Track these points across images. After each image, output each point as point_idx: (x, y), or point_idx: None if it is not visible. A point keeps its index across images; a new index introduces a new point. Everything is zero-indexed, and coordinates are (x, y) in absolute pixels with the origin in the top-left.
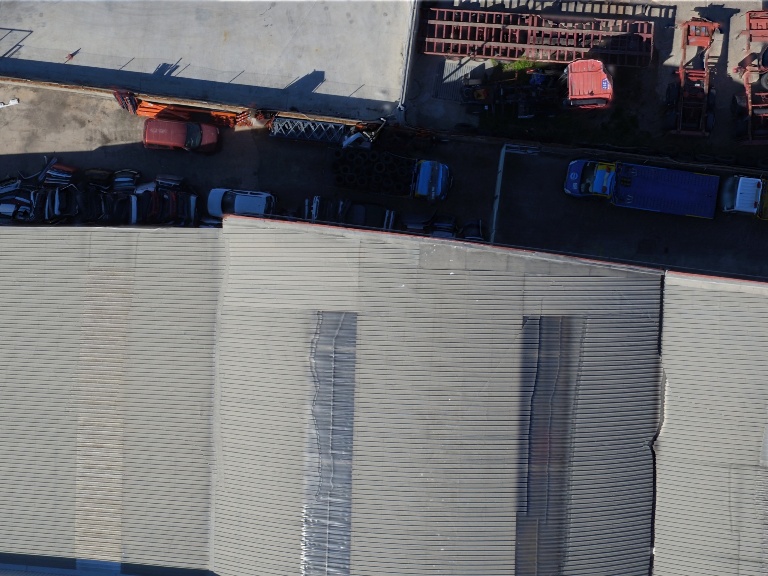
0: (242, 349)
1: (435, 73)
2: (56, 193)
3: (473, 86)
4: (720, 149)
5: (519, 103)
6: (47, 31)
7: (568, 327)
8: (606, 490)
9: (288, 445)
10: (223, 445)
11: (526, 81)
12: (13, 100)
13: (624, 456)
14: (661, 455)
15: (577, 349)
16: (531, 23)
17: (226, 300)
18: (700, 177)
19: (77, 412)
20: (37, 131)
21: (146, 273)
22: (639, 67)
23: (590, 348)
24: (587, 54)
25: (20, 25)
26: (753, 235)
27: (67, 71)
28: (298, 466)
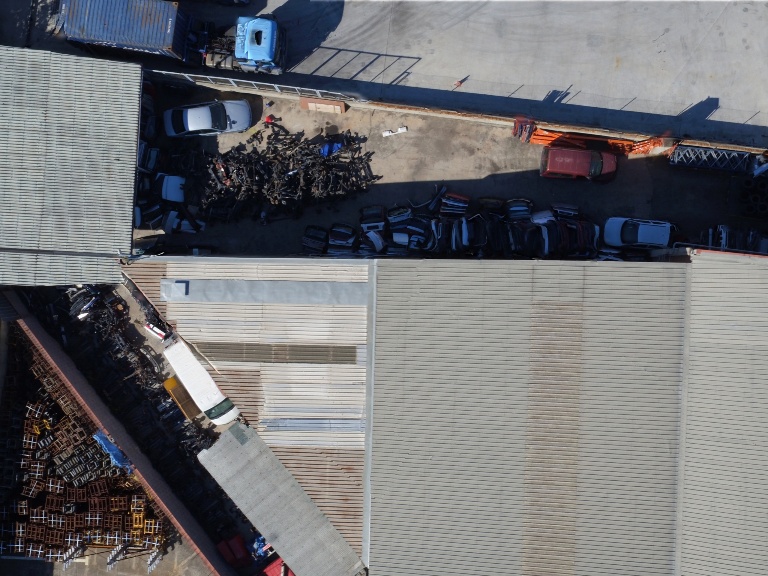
0: (725, 387)
1: None
2: (463, 223)
3: None
4: None
5: None
6: (436, 58)
7: None
8: None
9: (755, 483)
10: (684, 483)
11: None
12: (401, 128)
13: None
14: None
15: None
16: None
17: (691, 336)
18: None
19: (538, 449)
20: (425, 159)
21: (596, 308)
22: None
23: None
24: None
25: (408, 52)
26: None
27: (455, 98)
28: (763, 504)
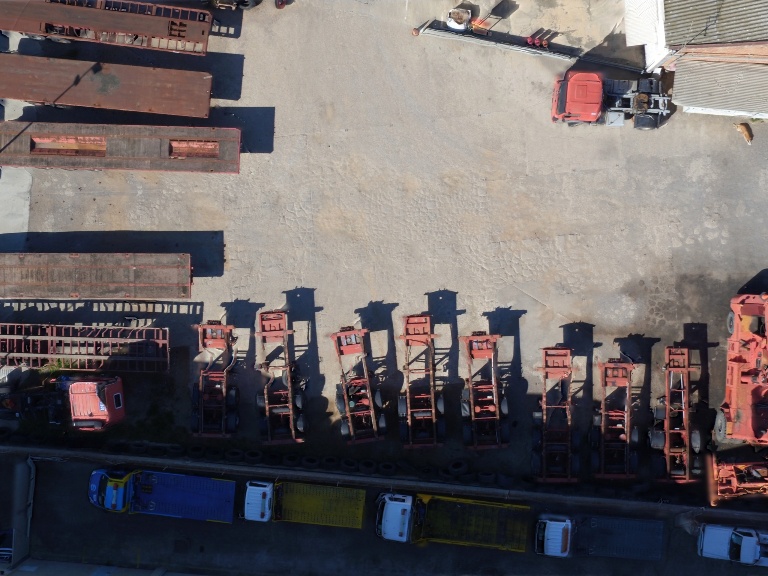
0: None
1: None
2: None
3: (2, 395)
4: (252, 443)
5: (49, 409)
6: None
7: None
8: None
9: None
10: None
11: (52, 389)
12: None
13: None
14: None
15: None
16: (50, 333)
17: None
18: (217, 483)
19: None
20: None
21: None
22: None
23: None
24: (106, 362)
25: None
26: (277, 535)
27: None
28: None
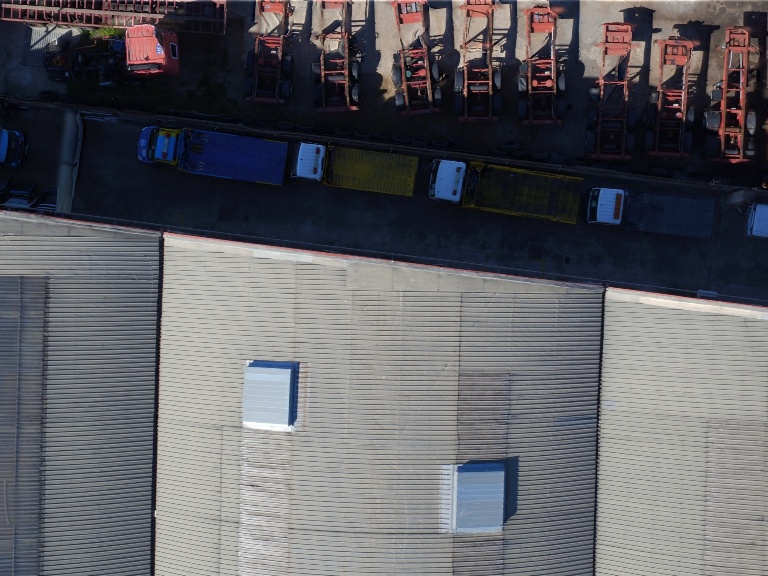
0: None
1: (23, 40)
2: None
3: (53, 53)
4: (303, 116)
5: (100, 70)
6: None
7: (29, 287)
8: (88, 452)
9: None
10: None
11: (104, 48)
12: None
13: (110, 418)
14: (165, 418)
15: (41, 310)
16: None
17: None
18: (269, 144)
19: None
20: None
21: None
22: (214, 33)
23: (56, 309)
24: (161, 20)
25: None
26: (327, 202)
27: None
28: None
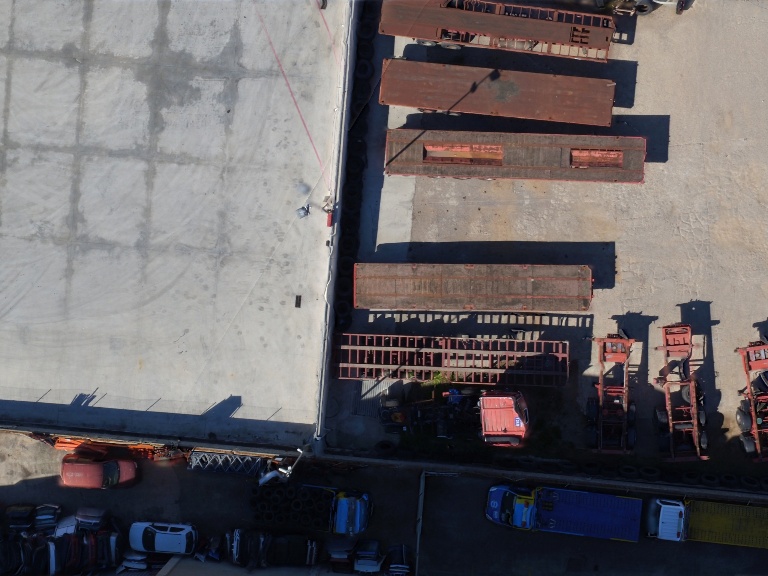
0: None
1: (353, 390)
2: None
3: (390, 408)
4: (645, 460)
5: (438, 423)
6: None
7: None
8: None
9: None
10: None
11: (443, 402)
12: None
13: None
14: None
15: None
16: (445, 346)
17: None
18: (622, 500)
19: None
20: None
21: None
22: (556, 386)
23: None
24: (503, 376)
25: None
26: (680, 554)
27: None
28: None
